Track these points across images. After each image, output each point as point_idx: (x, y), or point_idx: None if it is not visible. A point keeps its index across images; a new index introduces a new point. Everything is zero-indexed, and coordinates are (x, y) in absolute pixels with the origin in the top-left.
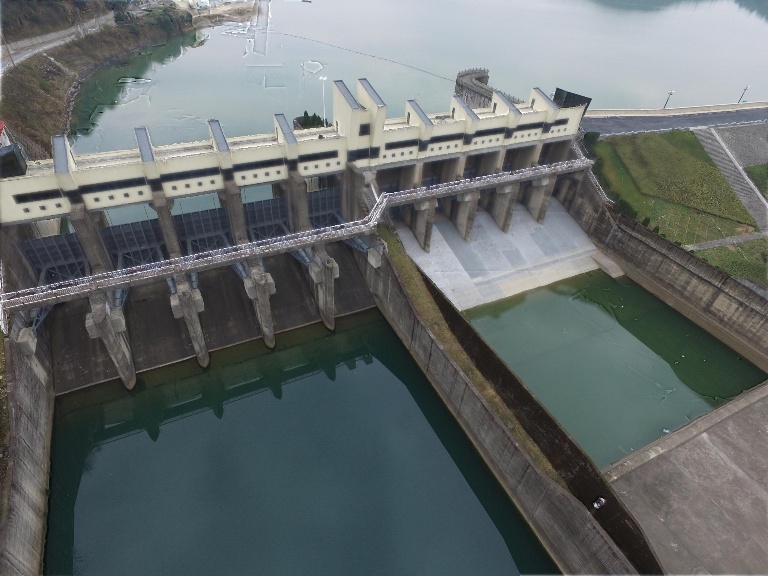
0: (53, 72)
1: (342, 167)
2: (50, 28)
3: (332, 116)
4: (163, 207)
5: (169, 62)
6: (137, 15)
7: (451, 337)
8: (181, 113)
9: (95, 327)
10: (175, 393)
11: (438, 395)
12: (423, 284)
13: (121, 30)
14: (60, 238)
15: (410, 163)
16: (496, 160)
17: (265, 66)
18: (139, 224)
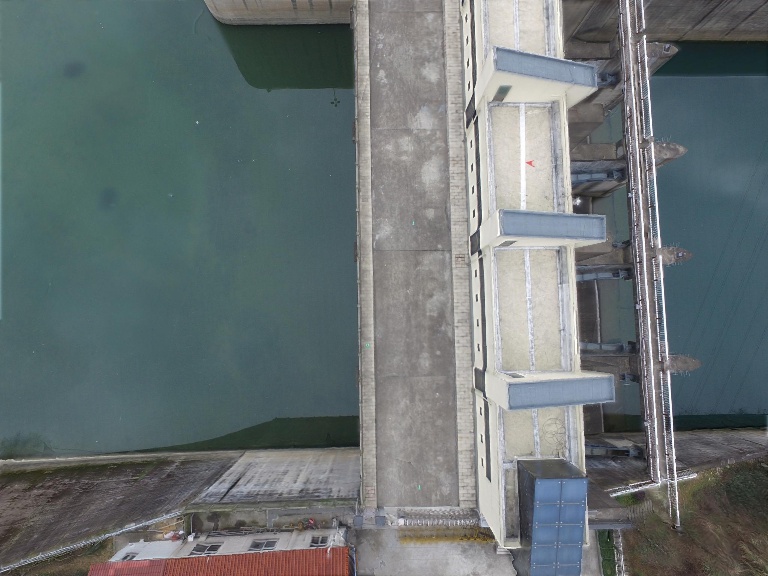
0: None
1: None
2: None
3: None
4: None
5: None
6: None
7: None
8: None
9: None
10: None
11: (748, 42)
12: None
13: None
14: None
15: None
16: None
17: None
18: None
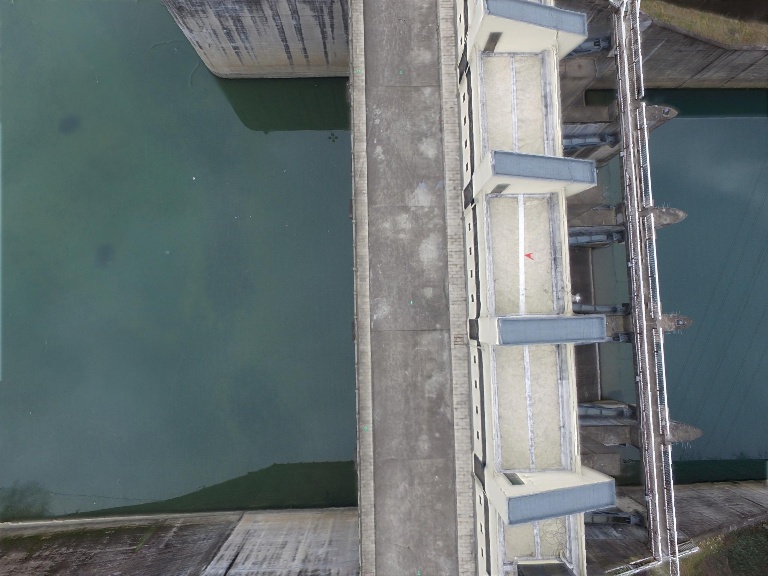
0: None
1: None
2: None
3: None
4: None
5: None
6: None
7: (753, 28)
8: None
9: None
10: None
11: (748, 89)
12: (674, 8)
13: None
14: None
15: None
16: None
17: None
18: None
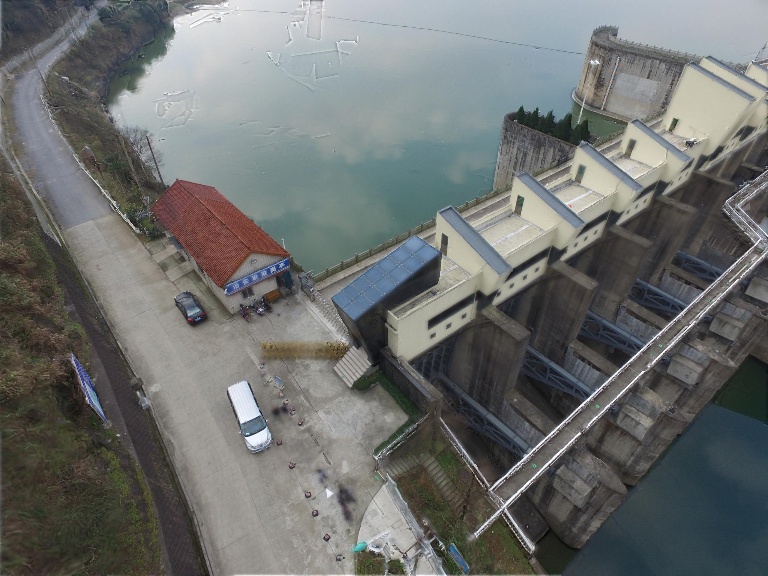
0: (79, 96)
1: (686, 178)
2: (35, 38)
3: (436, 104)
4: (597, 287)
5: (156, 62)
6: (118, 9)
7: None
8: (262, 126)
9: (589, 492)
10: (627, 535)
11: None
12: None
13: (110, 30)
14: (428, 356)
15: (724, 157)
16: (767, 135)
17: (314, 53)
18: (502, 309)
